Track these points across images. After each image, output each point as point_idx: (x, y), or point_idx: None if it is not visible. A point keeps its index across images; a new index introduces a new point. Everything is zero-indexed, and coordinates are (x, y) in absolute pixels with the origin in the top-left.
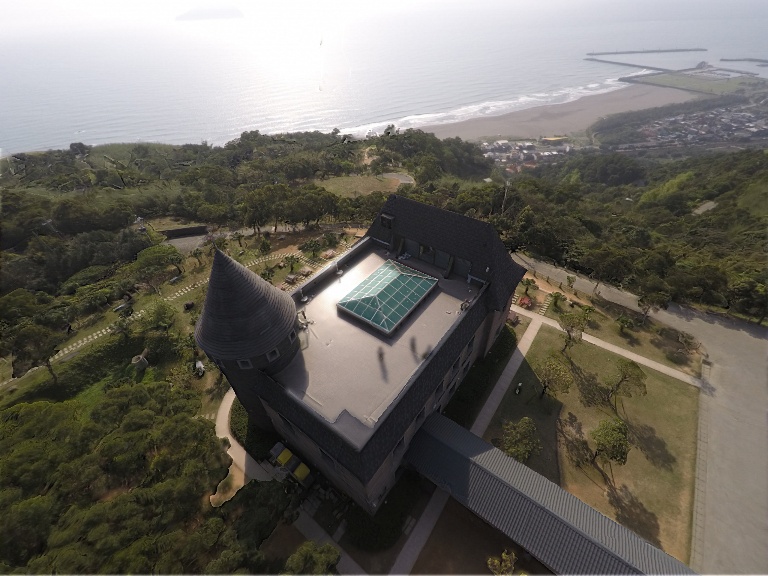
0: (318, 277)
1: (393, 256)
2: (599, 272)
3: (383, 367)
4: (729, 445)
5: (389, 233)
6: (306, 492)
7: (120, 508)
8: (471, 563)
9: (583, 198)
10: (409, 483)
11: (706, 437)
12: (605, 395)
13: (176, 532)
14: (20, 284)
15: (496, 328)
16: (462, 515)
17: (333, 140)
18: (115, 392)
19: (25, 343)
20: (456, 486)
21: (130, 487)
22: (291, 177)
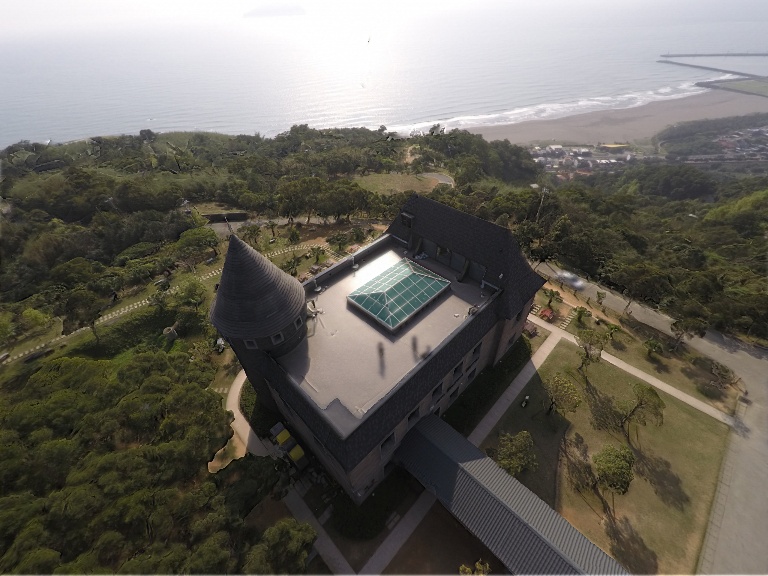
0: (333, 269)
1: (410, 255)
2: (632, 290)
3: (382, 362)
4: (755, 492)
5: (408, 232)
6: (299, 473)
7: (128, 460)
8: (449, 568)
9: (636, 211)
10: (399, 480)
11: (729, 480)
12: (619, 420)
13: (172, 489)
14: (82, 253)
15: (509, 337)
16: (447, 519)
17: (378, 137)
18: (139, 357)
19: (74, 305)
20: (441, 489)
21: (141, 443)
22: (332, 171)
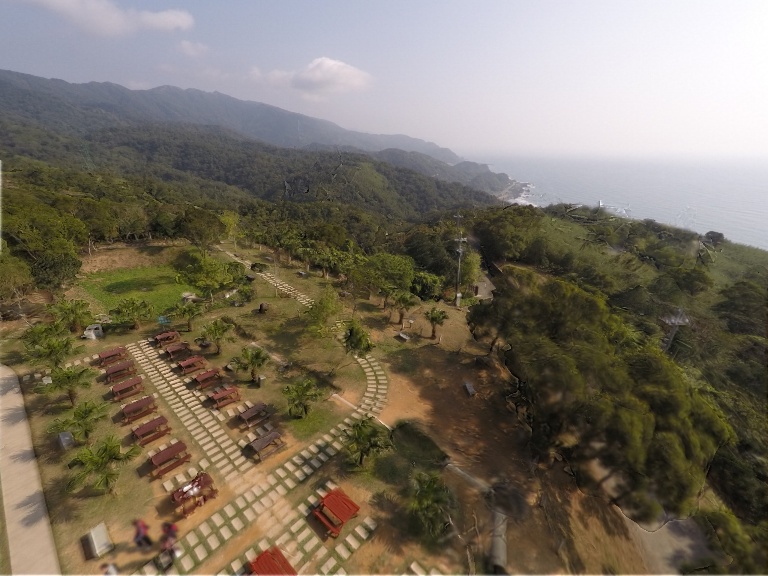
0: None
1: None
2: None
3: None
4: None
5: None
6: None
7: None
8: None
9: None
10: None
11: None
12: None
13: None
14: None
15: None
16: None
17: None
18: None
19: None
20: None
21: None
22: None
